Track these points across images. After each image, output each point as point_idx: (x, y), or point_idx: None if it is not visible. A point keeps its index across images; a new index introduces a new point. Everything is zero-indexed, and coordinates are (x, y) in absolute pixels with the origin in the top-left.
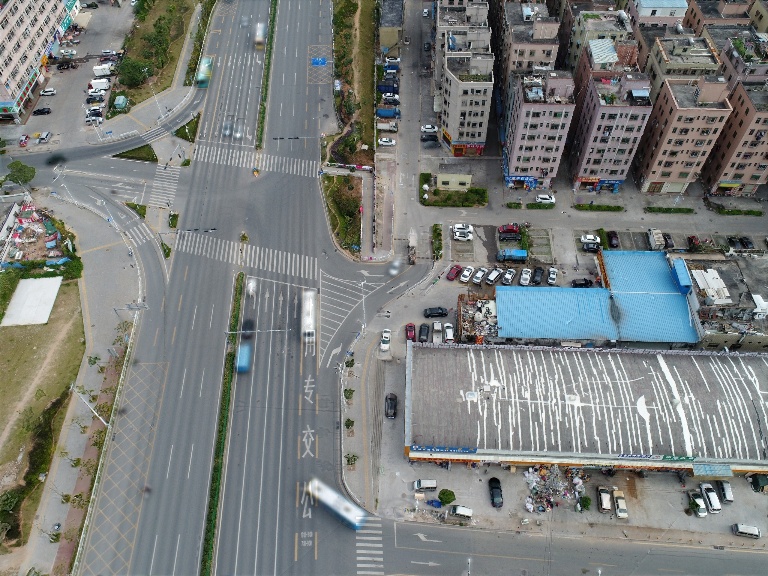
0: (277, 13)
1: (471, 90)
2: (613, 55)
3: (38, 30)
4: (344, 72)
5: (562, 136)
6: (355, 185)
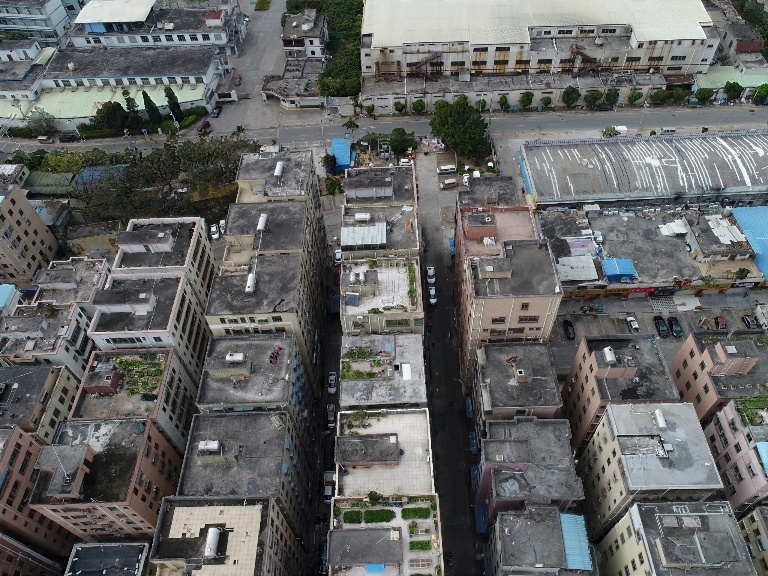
0: None
1: None
2: None
3: None
4: None
5: None
6: None
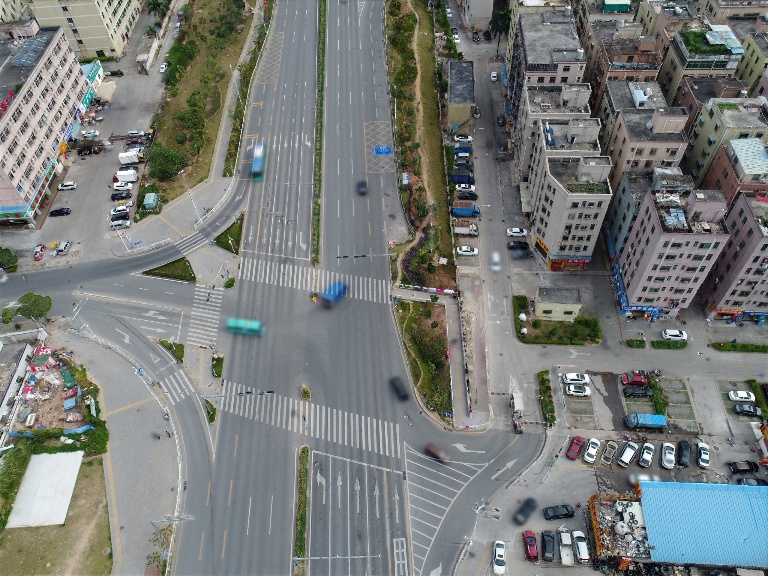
0: (325, 80)
1: (582, 202)
2: (767, 163)
3: (56, 114)
4: (409, 158)
5: (705, 267)
6: (437, 316)
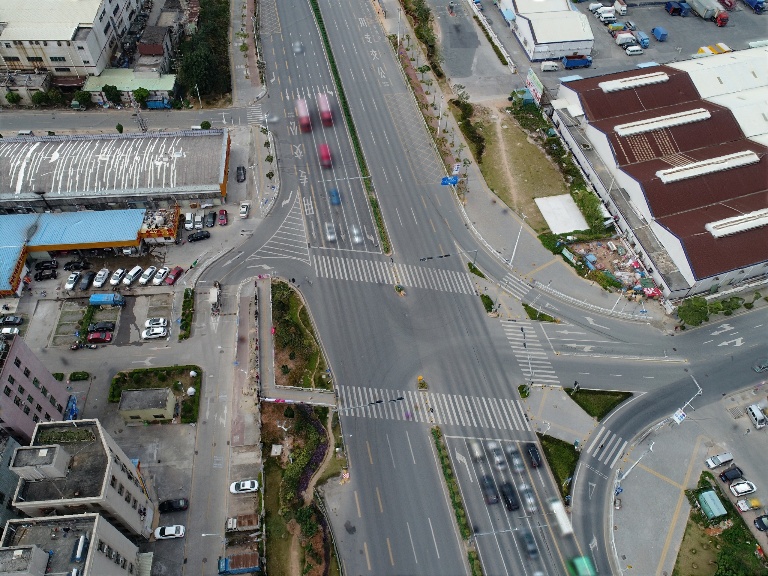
0: None
1: None
2: None
3: None
4: None
5: None
6: None
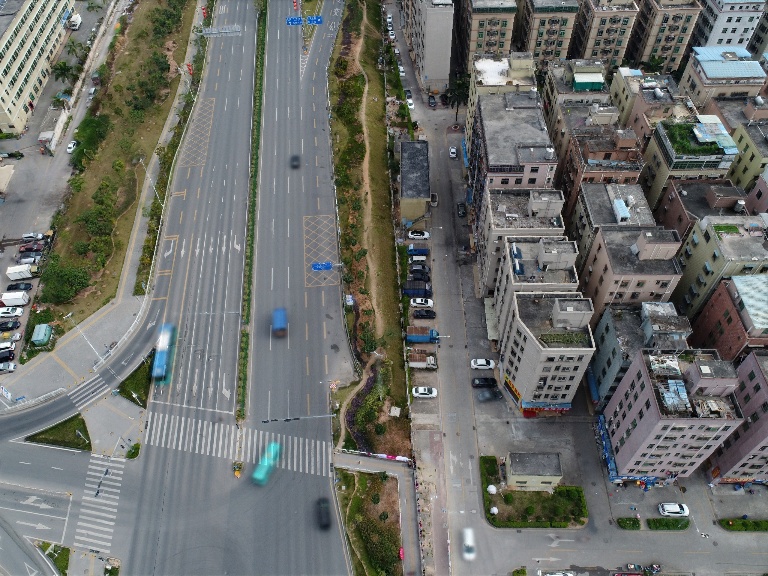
0: (260, 161)
1: (559, 356)
2: None
3: None
4: (355, 267)
5: (712, 445)
6: (387, 494)
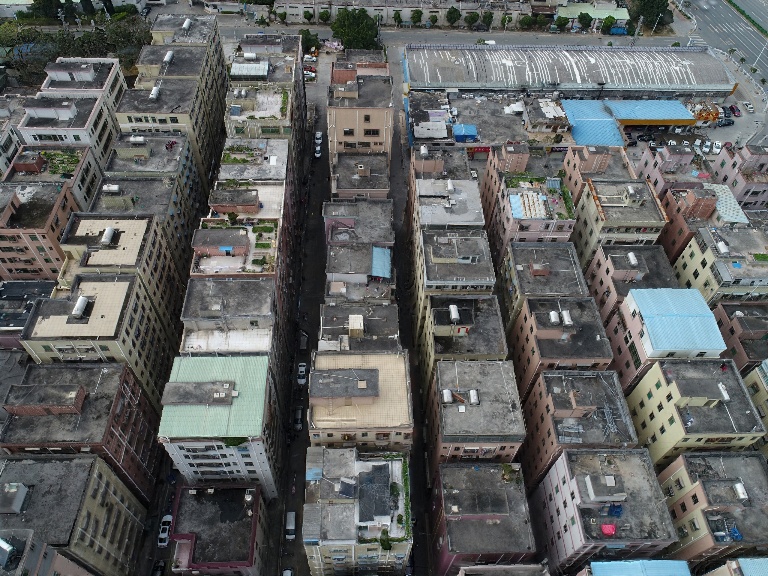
0: None
1: None
2: None
3: None
4: None
5: None
6: None
